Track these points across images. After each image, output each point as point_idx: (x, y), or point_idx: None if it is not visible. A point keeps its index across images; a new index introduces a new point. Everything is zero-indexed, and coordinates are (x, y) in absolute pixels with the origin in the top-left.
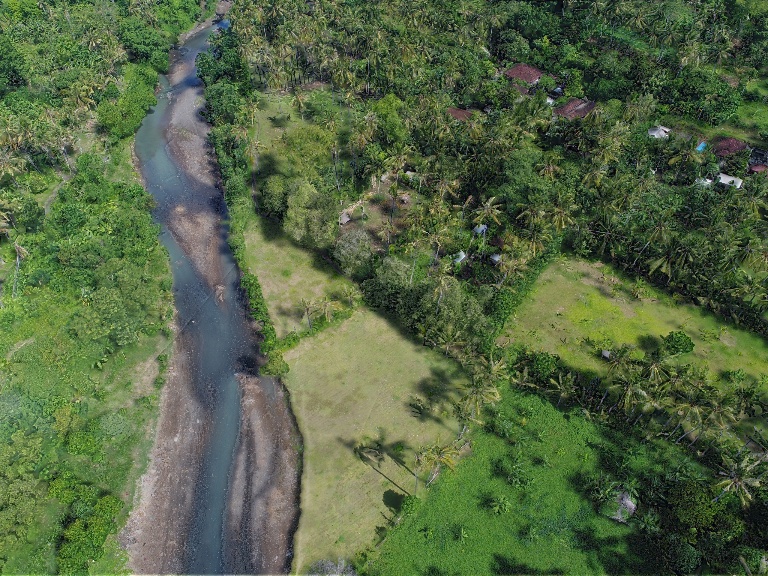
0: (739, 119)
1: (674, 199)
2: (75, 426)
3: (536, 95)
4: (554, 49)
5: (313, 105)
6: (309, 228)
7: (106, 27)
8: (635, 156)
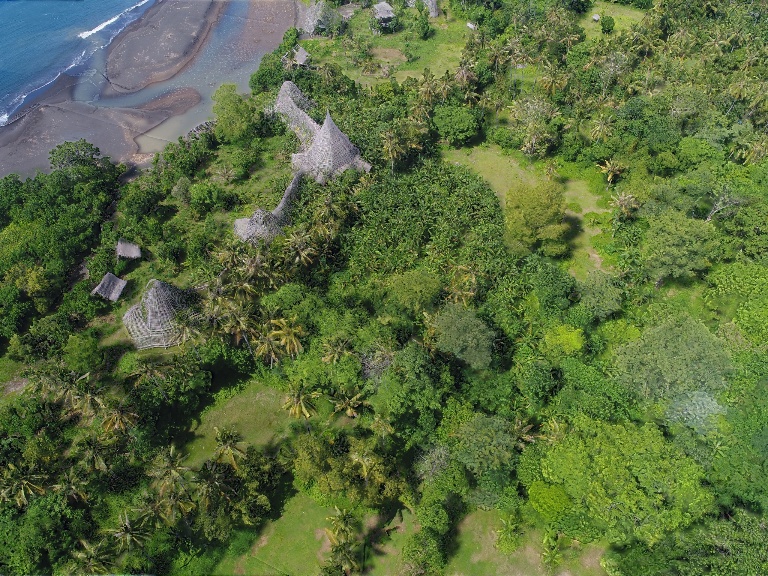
0: None
1: None
2: None
3: None
4: None
5: None
6: None
7: None
8: None
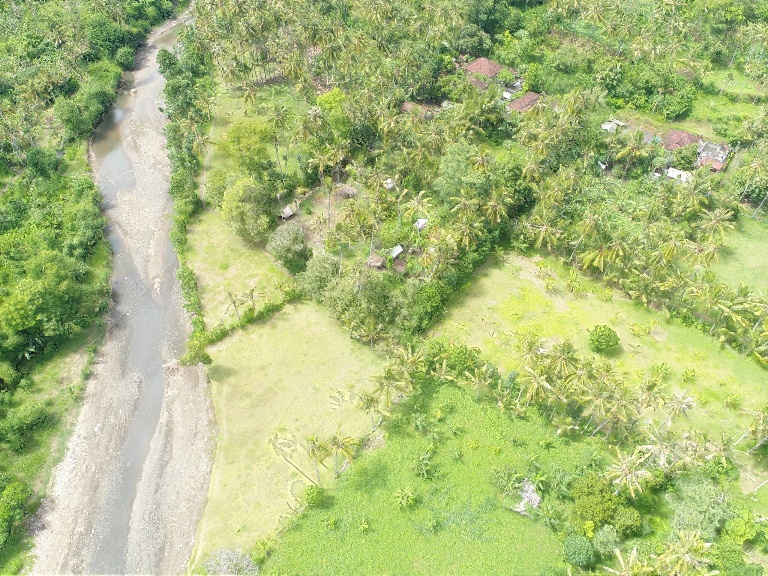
0: (693, 113)
1: (620, 193)
2: None
3: (488, 90)
4: (516, 44)
5: (272, 101)
6: (245, 222)
7: (72, 25)
8: (583, 150)
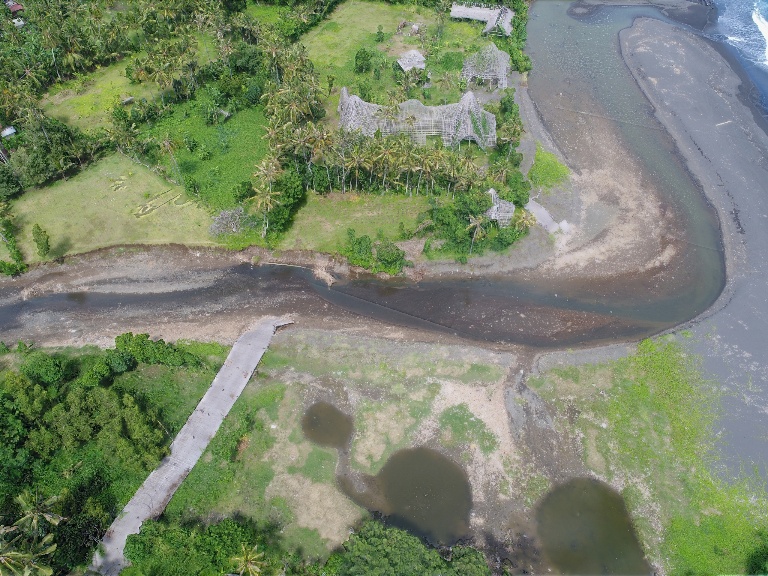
0: None
1: None
2: None
3: None
4: None
5: None
6: None
7: None
8: None
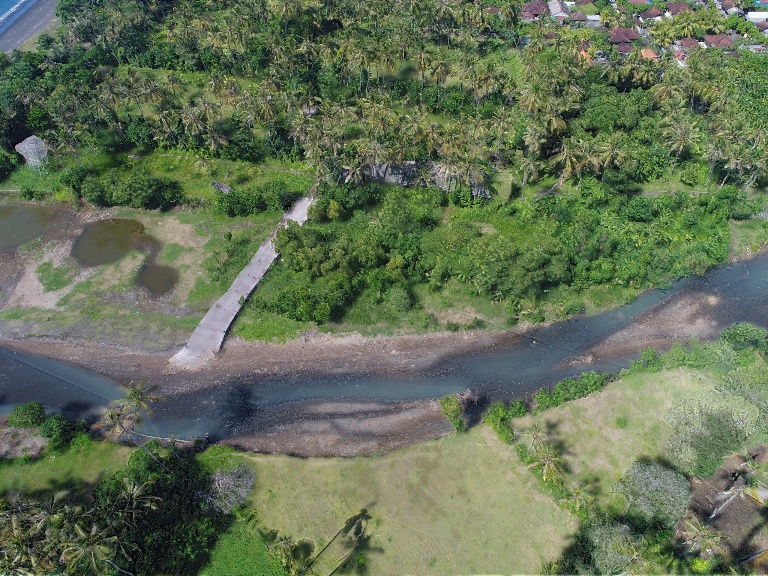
0: None
1: None
2: (396, 275)
3: None
4: None
5: None
6: None
7: None
8: None
